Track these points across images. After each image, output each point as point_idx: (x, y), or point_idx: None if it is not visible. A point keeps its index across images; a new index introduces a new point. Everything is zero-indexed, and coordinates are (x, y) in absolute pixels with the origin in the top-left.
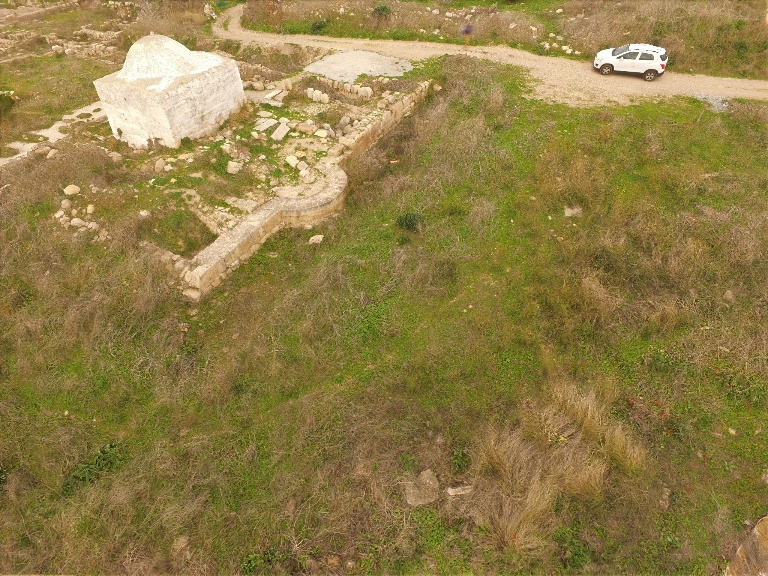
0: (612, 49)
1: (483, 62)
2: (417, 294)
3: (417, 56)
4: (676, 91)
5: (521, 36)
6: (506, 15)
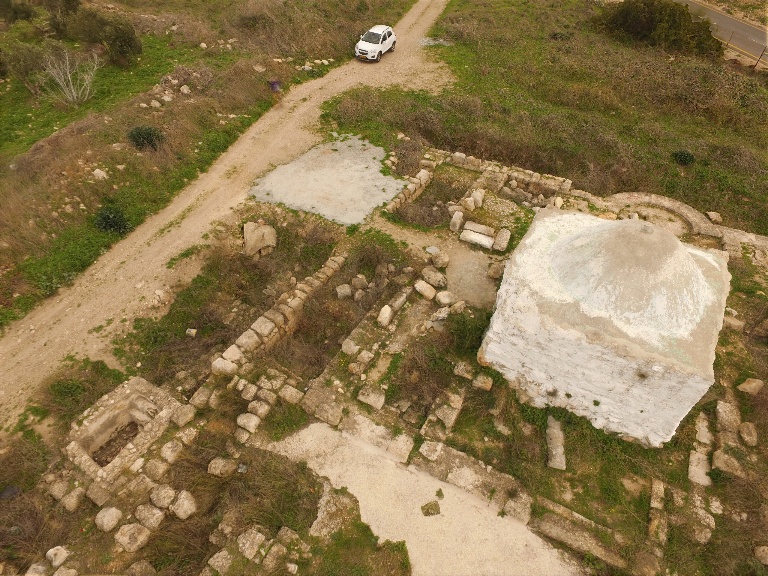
0: (362, 41)
1: (330, 105)
2: (759, 159)
3: (302, 138)
4: (415, 47)
5: (289, 71)
6: (246, 61)
